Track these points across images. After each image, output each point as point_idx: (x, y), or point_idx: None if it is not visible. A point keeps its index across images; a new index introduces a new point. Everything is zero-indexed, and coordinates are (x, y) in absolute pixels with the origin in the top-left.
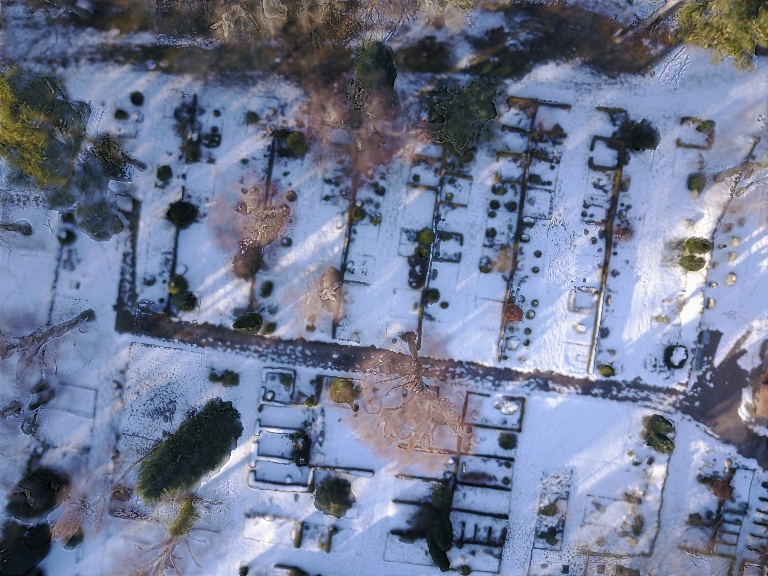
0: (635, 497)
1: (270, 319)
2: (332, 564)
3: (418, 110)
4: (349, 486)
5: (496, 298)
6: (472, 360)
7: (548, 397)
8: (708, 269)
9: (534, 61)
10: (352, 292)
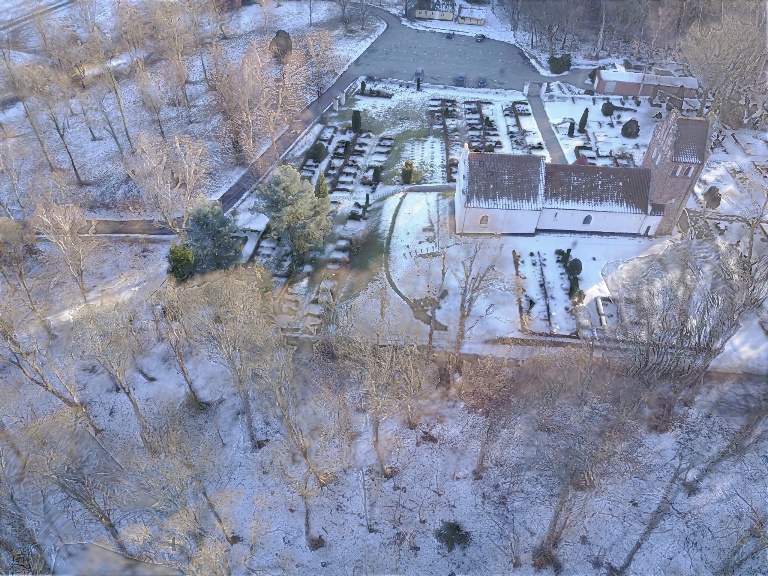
0: (703, 183)
1: None
2: None
3: None
4: None
5: None
6: None
7: None
8: None
9: None
10: None
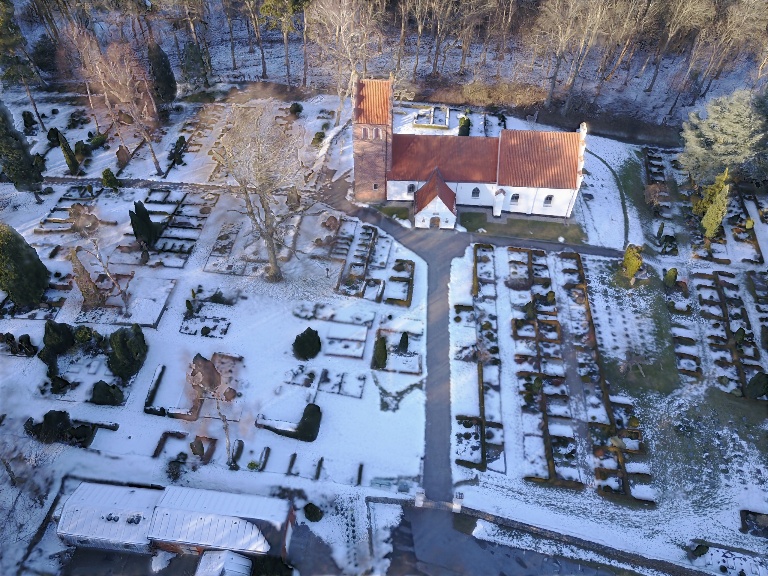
0: None
1: (85, 172)
2: (71, 267)
3: (192, 112)
4: (97, 220)
5: (214, 163)
6: (194, 183)
7: (234, 194)
8: (328, 149)
9: (251, 98)
10: (135, 162)
